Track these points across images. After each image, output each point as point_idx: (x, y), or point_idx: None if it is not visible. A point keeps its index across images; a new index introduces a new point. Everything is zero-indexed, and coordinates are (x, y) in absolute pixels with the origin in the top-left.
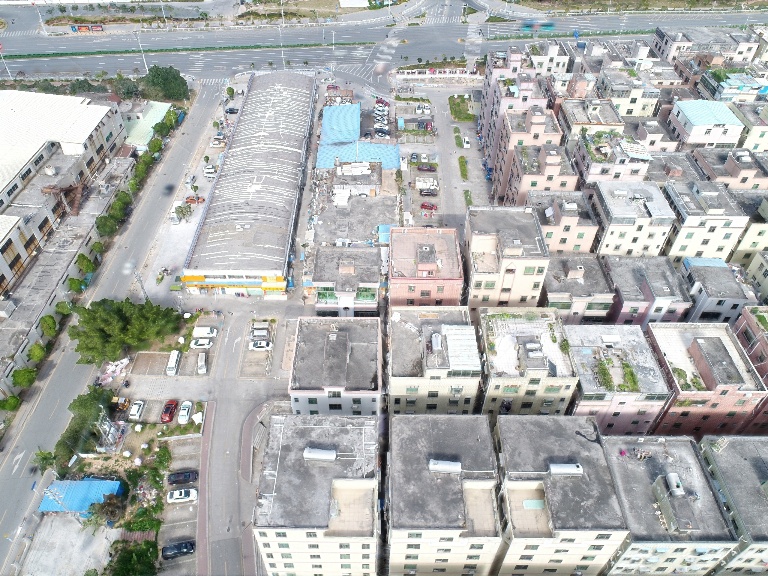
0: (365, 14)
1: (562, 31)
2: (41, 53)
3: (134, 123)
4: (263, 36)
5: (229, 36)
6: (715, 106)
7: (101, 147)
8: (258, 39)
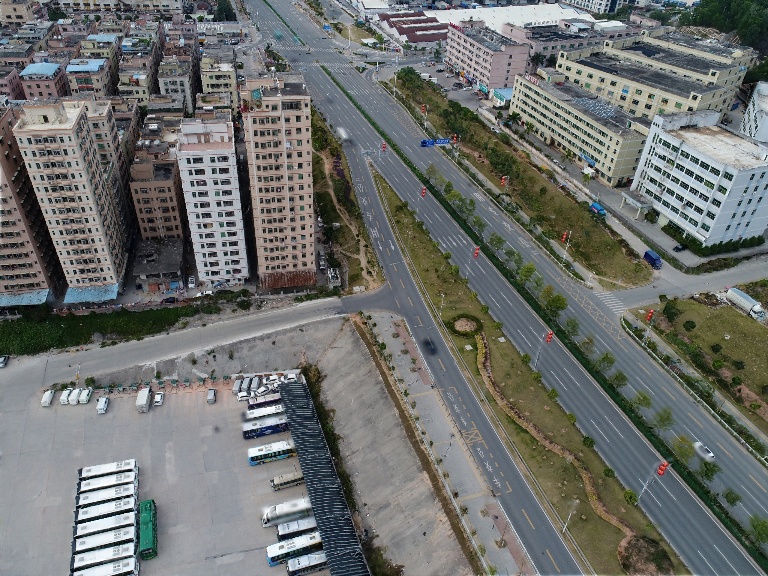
0: (352, 43)
1: (349, 84)
2: (272, 4)
3: (193, 14)
4: (308, 29)
5: (305, 24)
6: (107, 38)
7: (158, 6)
8: (303, 28)
